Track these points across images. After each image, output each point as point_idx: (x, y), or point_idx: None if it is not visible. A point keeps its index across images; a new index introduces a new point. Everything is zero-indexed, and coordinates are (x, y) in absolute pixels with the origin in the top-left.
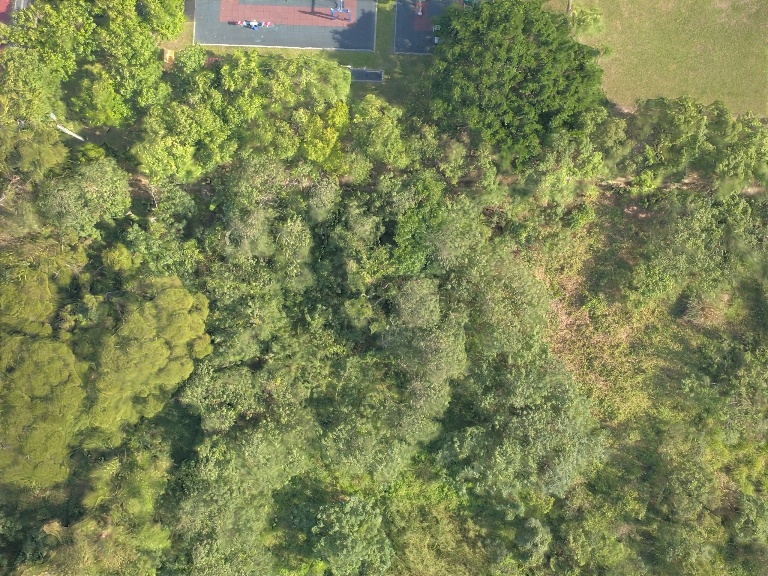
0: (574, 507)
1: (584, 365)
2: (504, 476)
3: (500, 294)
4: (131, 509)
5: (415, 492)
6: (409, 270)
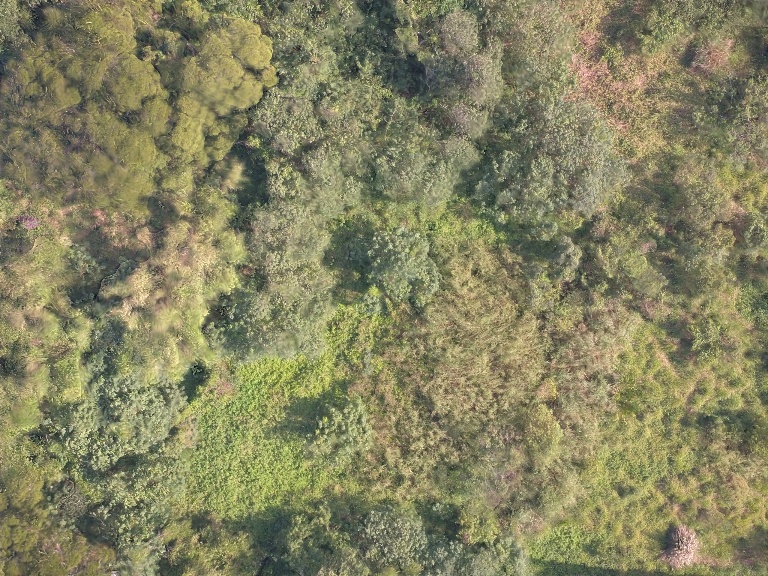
0: (601, 230)
1: (605, 110)
2: (539, 194)
3: (531, 23)
4: (211, 220)
5: (457, 230)
6: (449, 10)
